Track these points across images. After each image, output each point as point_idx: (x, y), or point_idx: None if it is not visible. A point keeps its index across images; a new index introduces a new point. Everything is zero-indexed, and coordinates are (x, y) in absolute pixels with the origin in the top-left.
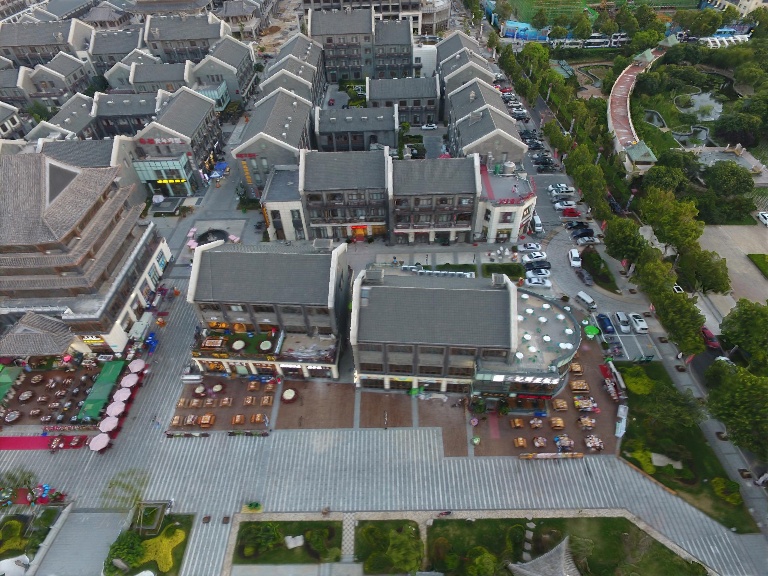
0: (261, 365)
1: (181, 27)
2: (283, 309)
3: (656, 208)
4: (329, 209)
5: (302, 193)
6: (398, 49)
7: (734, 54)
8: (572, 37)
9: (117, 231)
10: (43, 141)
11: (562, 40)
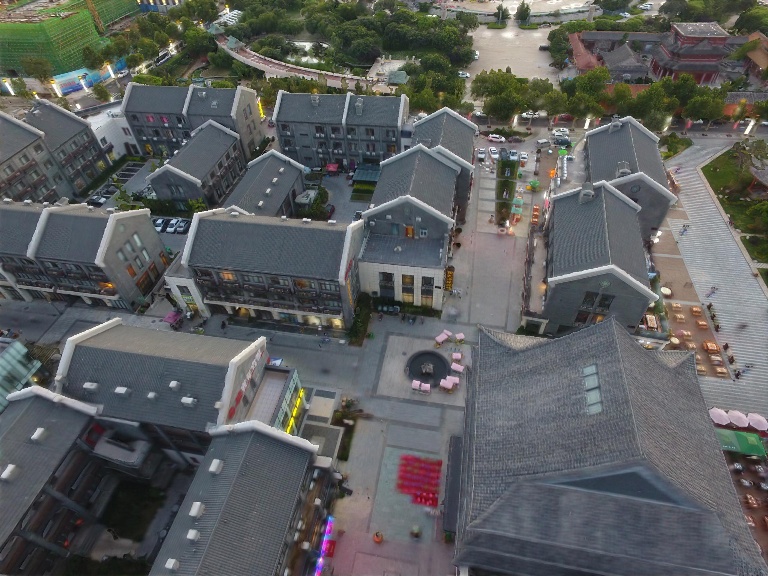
0: None
1: None
2: None
3: (490, 82)
4: None
5: (452, 225)
6: (78, 141)
7: (266, 19)
8: (146, 59)
9: None
10: None
11: (140, 66)
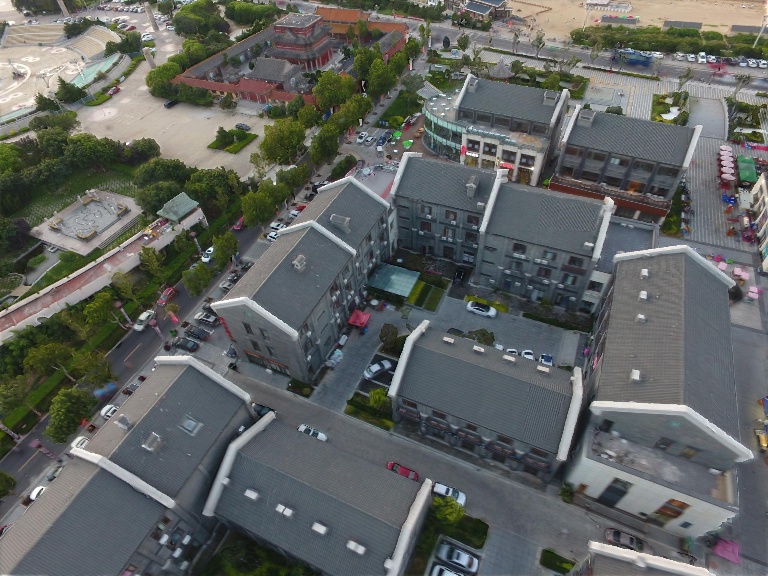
0: None
1: None
2: None
3: None
4: None
5: None
6: None
7: None
8: None
9: None
10: None
11: None
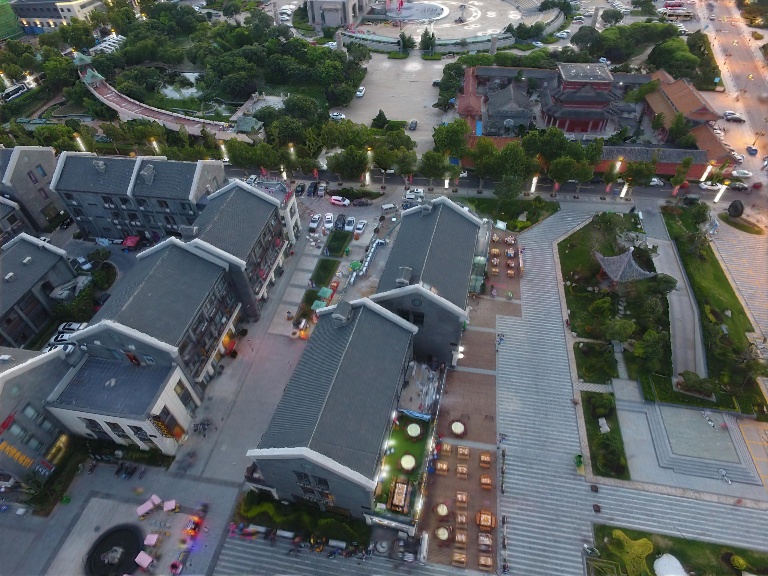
0: None
1: None
2: None
3: (337, 135)
4: None
5: (177, 353)
6: None
7: (143, 47)
8: None
9: None
10: None
11: None
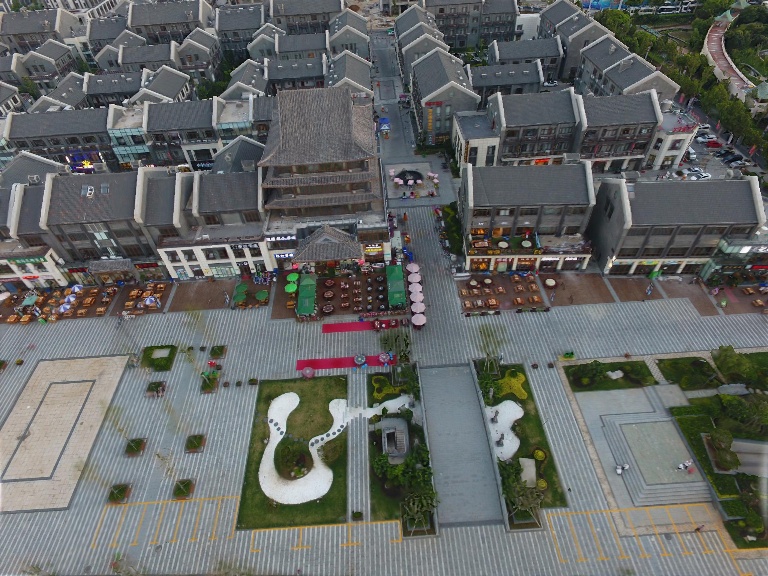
0: (524, 260)
1: (303, 3)
2: (545, 211)
3: None
4: (521, 144)
5: (504, 129)
6: (503, 17)
7: None
8: (647, 4)
9: None
10: (252, 97)
11: (638, 7)
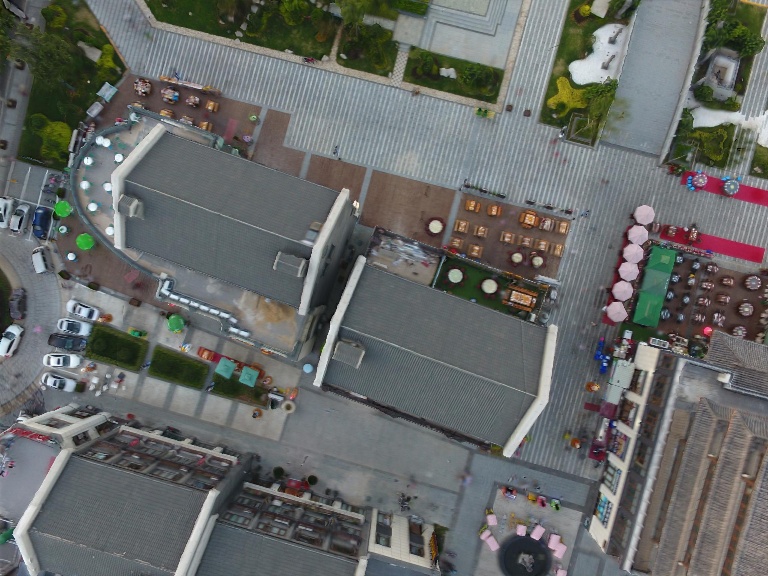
0: None
1: None
2: None
3: None
4: None
5: None
6: None
7: None
8: None
9: (685, 530)
10: None
11: None
